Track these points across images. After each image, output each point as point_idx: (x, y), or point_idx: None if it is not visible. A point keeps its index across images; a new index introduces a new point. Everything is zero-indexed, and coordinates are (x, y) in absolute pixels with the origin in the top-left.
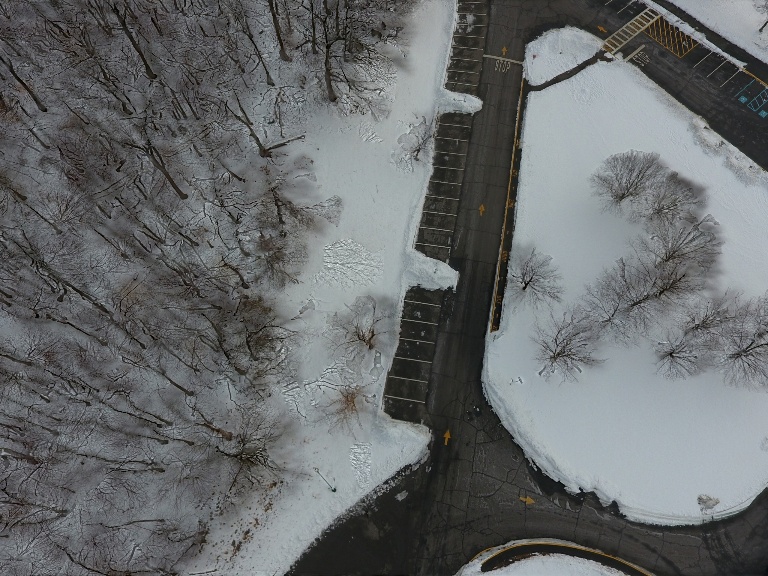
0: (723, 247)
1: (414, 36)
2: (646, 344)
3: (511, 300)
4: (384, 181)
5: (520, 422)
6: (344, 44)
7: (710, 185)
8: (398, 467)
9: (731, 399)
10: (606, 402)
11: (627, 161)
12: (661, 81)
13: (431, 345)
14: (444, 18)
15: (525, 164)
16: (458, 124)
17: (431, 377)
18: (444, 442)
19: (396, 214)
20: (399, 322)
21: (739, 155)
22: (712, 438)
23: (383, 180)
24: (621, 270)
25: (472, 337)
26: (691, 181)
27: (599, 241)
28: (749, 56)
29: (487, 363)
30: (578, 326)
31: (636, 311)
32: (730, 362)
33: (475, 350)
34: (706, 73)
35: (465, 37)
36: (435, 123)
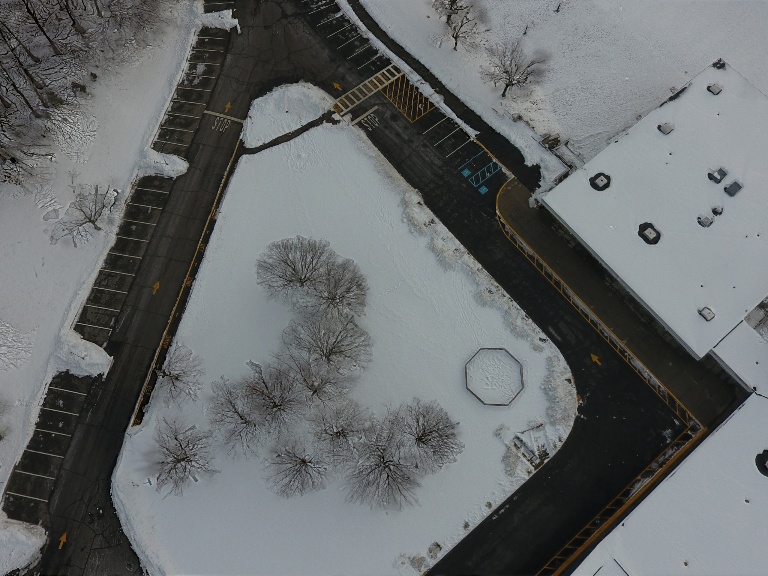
0: (404, 339)
1: (129, 88)
2: (266, 455)
3: (160, 392)
4: (54, 253)
5: (137, 529)
6: (39, 98)
7: (407, 269)
8: (4, 572)
9: (372, 510)
10: (237, 509)
11: (293, 248)
12: (385, 148)
13: (67, 438)
14: (172, 67)
15: (215, 238)
16: (156, 189)
17: (60, 473)
18: (58, 546)
19: (60, 290)
20: (38, 411)
21: (446, 236)
22: (343, 552)
23: (53, 252)
24: (255, 372)
25: (112, 431)
26: (388, 263)
27: (259, 332)
28: (484, 124)
29: (120, 461)
30: (192, 434)
31: (273, 415)
32: (363, 475)
33: (112, 445)
34: (434, 141)
35: (189, 90)
36: (131, 187)
